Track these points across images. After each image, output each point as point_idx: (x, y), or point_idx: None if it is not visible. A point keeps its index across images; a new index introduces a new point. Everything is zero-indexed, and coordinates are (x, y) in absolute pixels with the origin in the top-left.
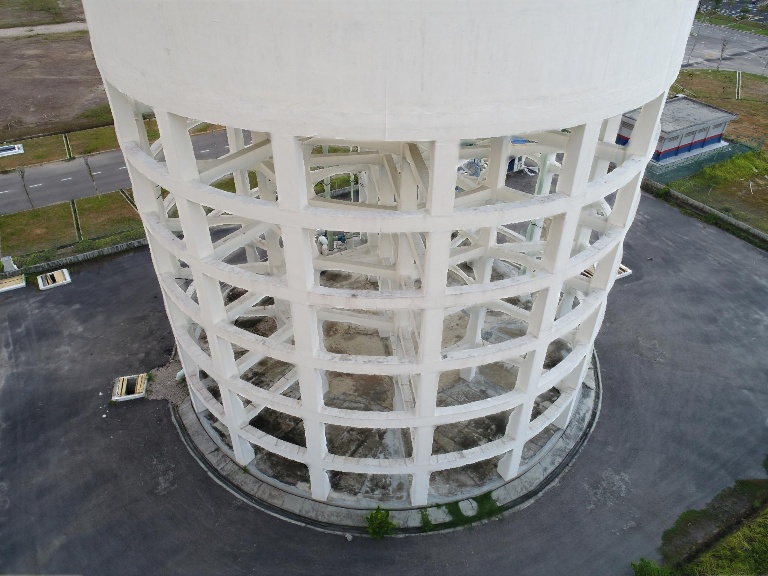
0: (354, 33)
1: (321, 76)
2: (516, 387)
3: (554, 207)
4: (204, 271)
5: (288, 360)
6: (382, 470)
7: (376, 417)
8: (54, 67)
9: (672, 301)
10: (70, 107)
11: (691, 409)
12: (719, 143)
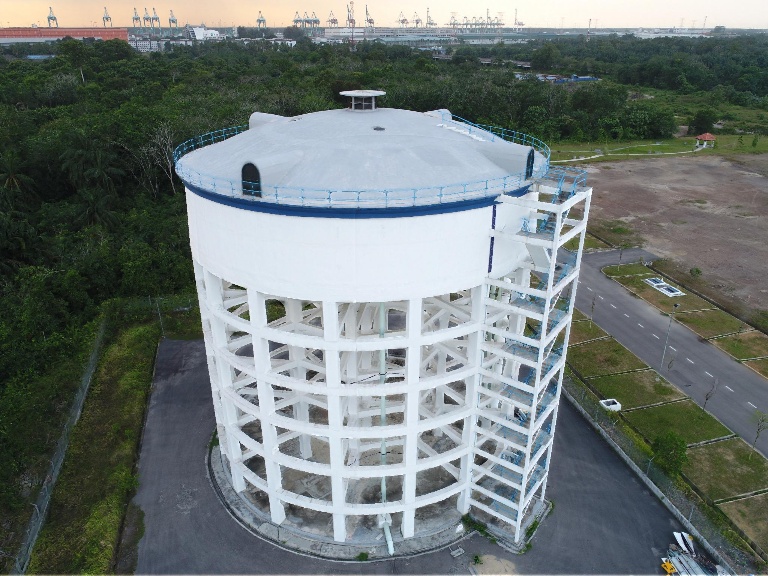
0: None
1: None
2: None
3: None
4: None
5: None
6: None
7: None
8: None
9: None
10: None
11: None
12: None
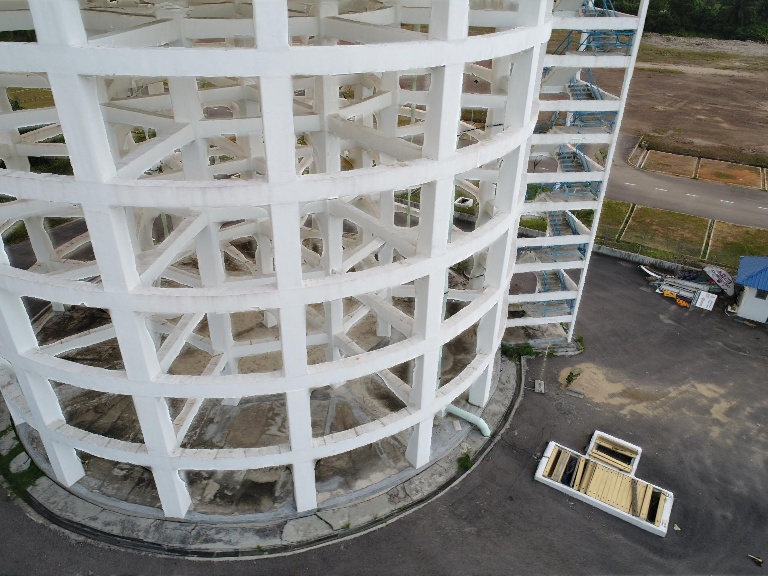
0: None
1: None
2: None
3: None
4: None
5: None
6: None
7: None
8: None
9: None
10: None
11: None
12: None
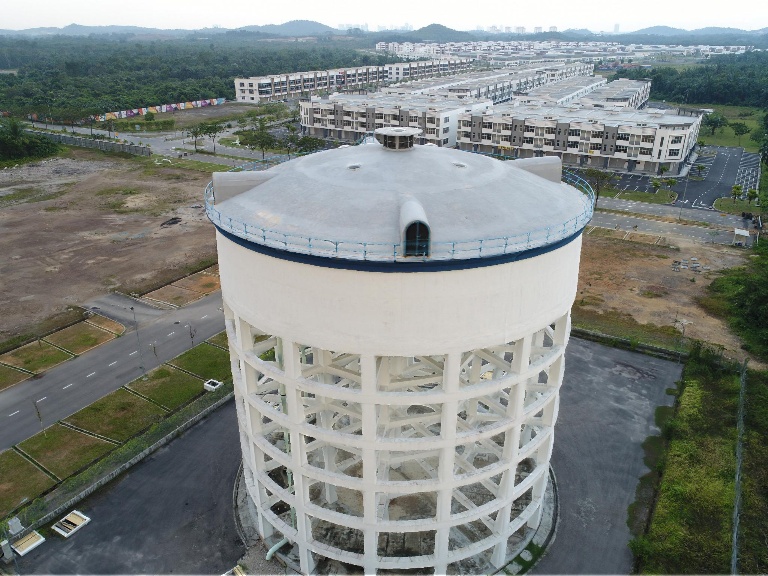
0: (495, 299)
1: (478, 321)
2: (538, 462)
3: (559, 353)
4: (377, 448)
5: (435, 489)
6: (484, 548)
7: (484, 509)
8: None
9: None
10: None
11: (594, 447)
12: None
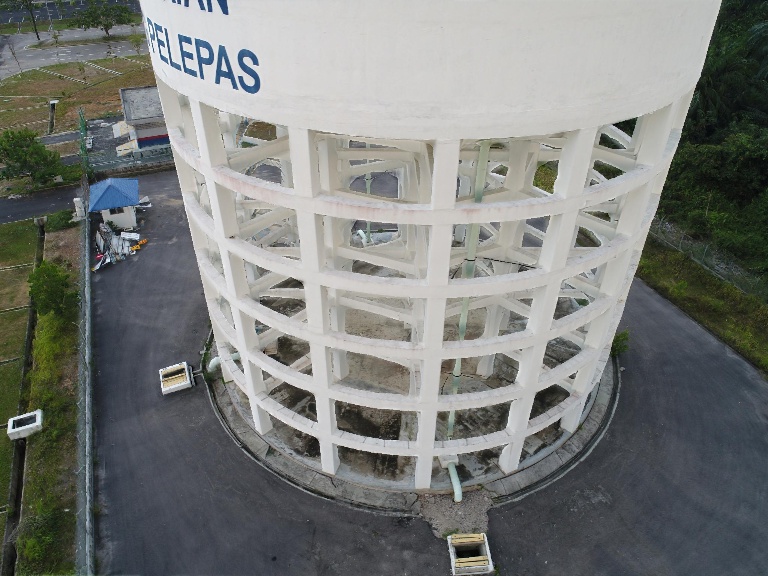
0: None
1: None
2: None
3: None
4: None
5: None
6: None
7: None
8: None
9: (382, 190)
10: None
11: None
12: None
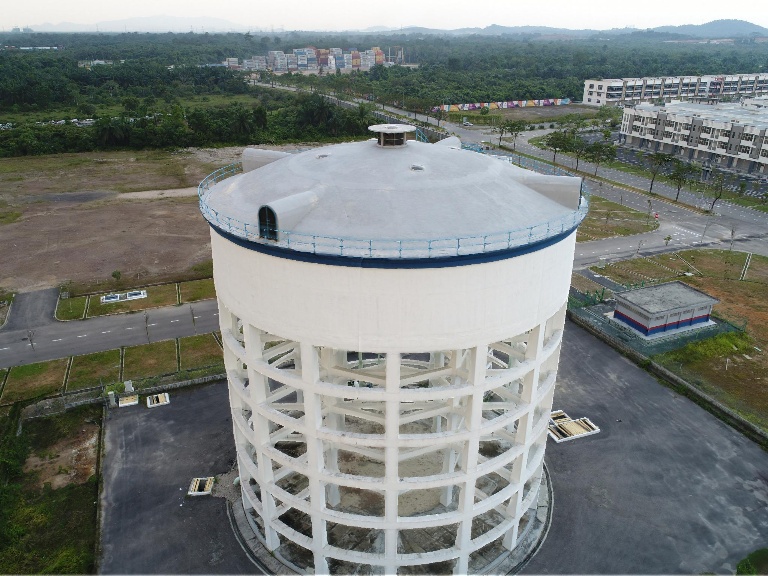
0: (343, 301)
1: (327, 318)
2: (458, 508)
3: (463, 391)
4: (259, 411)
5: (303, 473)
6: (362, 560)
7: (358, 519)
8: (176, 226)
9: (628, 458)
10: (184, 261)
11: (620, 547)
12: (707, 322)
